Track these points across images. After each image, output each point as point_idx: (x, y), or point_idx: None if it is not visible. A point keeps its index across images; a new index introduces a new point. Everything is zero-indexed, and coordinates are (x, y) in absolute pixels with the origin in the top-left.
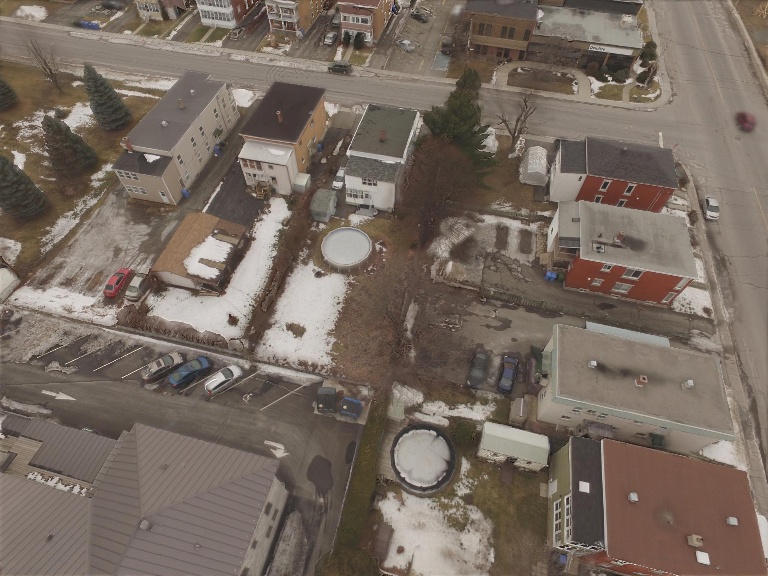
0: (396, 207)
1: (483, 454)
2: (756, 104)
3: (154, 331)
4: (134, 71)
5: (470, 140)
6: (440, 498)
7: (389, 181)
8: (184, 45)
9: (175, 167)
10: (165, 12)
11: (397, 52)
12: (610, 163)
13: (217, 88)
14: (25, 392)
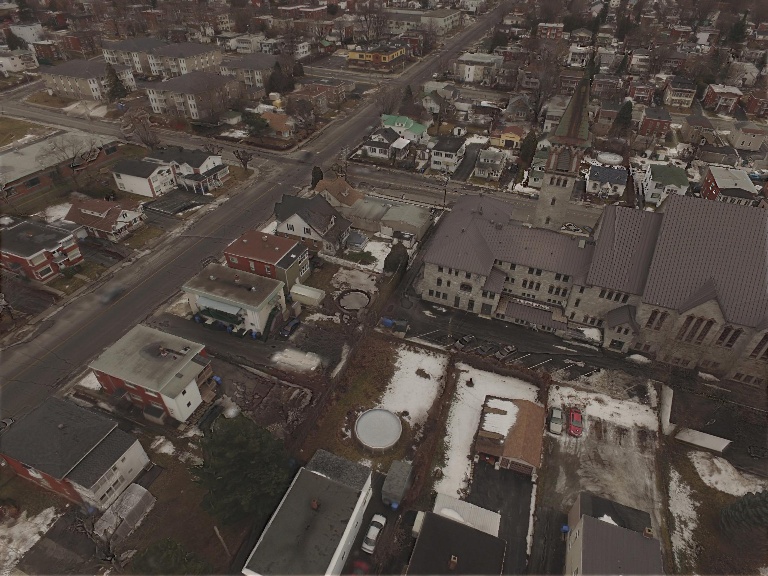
0: None
1: None
2: None
3: None
4: None
5: None
6: None
7: (325, 451)
8: None
9: None
10: None
11: None
12: (87, 424)
13: None
14: (587, 352)
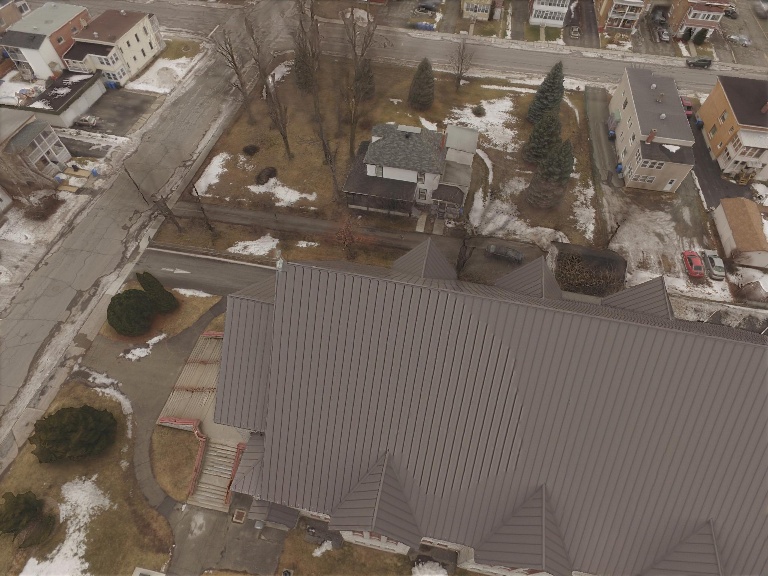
0: None
1: None
2: None
3: None
4: (506, 69)
5: None
6: None
7: None
8: (529, 44)
9: None
10: (492, 12)
11: (736, 47)
12: None
13: (671, 82)
14: None
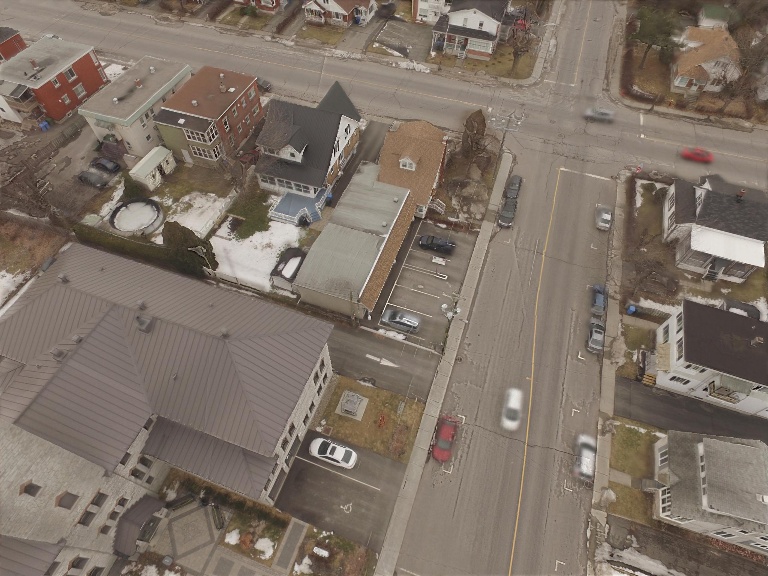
0: None
1: (152, 186)
2: None
3: None
4: None
5: None
6: (168, 214)
7: None
8: None
9: None
10: None
11: None
12: None
13: None
14: None
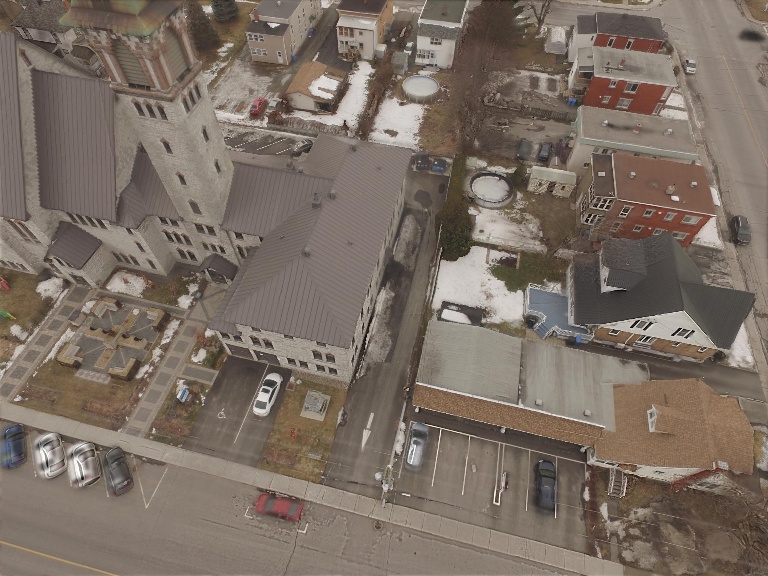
0: (454, 64)
1: (531, 188)
2: (728, 6)
3: (295, 126)
4: None
5: (512, 6)
6: (504, 210)
7: (451, 39)
8: None
9: (289, 34)
10: None
11: None
12: (614, 24)
13: None
14: None
